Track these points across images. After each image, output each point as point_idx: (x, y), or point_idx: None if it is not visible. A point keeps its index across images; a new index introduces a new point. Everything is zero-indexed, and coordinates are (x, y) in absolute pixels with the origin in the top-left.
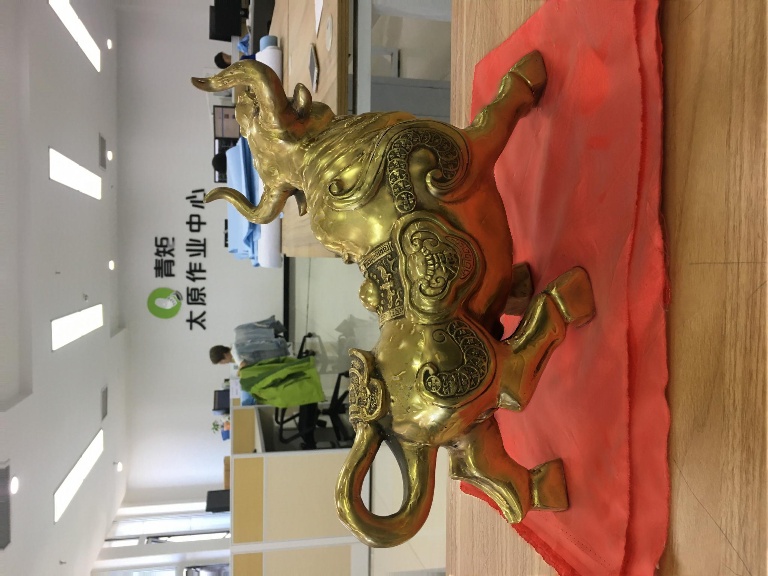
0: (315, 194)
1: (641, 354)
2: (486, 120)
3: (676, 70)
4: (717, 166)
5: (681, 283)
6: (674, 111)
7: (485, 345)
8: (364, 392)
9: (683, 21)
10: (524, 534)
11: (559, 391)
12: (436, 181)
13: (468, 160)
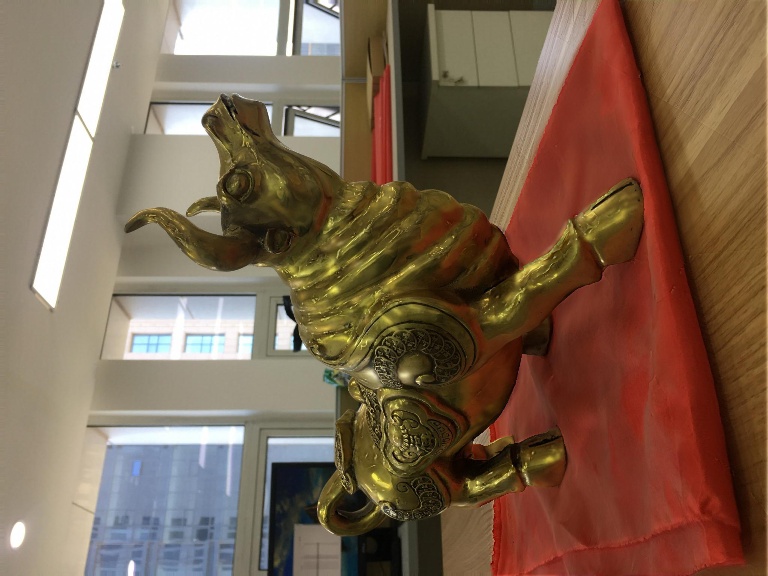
0: None
1: (561, 568)
2: (515, 312)
3: None
4: None
5: None
6: None
7: (442, 497)
8: (341, 473)
9: None
10: (491, 431)
11: None
12: (427, 383)
13: (473, 363)
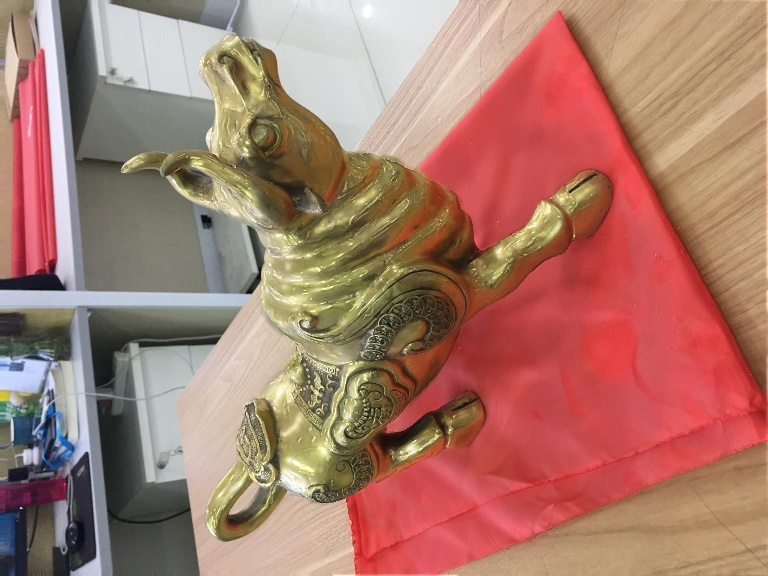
0: (280, 298)
1: (475, 517)
2: (502, 280)
3: (653, 492)
4: (604, 570)
5: (528, 550)
6: (624, 500)
7: None
8: (259, 466)
9: (692, 488)
10: None
11: (410, 421)
12: (413, 351)
13: None
